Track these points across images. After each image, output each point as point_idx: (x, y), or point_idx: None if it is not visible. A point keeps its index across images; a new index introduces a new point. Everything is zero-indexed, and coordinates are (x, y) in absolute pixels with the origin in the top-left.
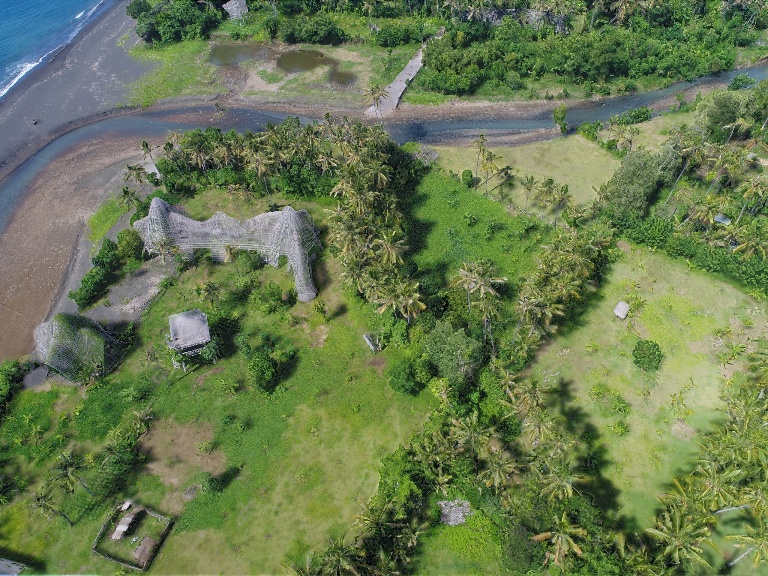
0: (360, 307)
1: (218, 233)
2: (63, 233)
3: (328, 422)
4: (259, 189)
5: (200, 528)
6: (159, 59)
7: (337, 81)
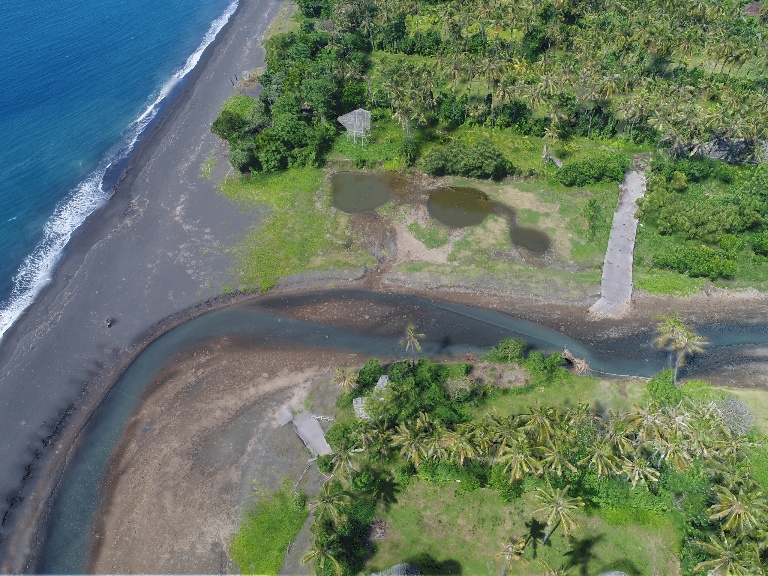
0: None
1: None
2: None
3: None
4: (510, 498)
5: None
6: (264, 201)
7: (524, 245)
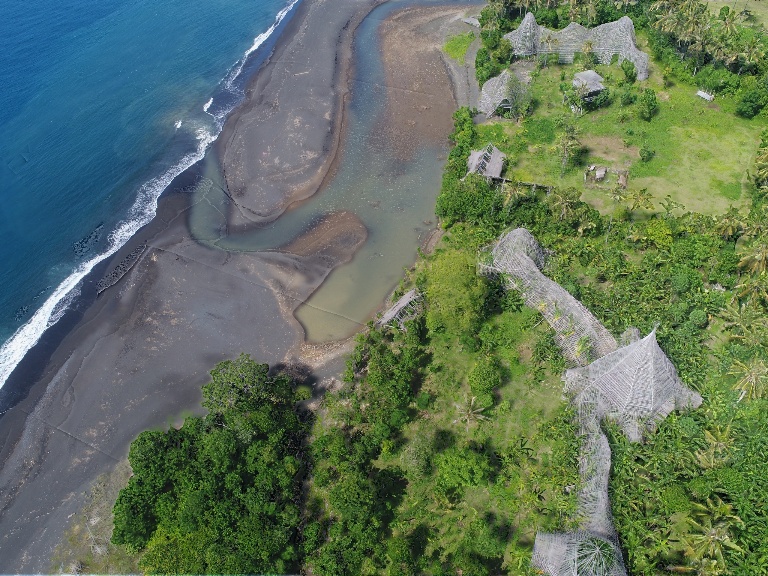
0: (687, 79)
1: (569, 39)
2: (428, 56)
3: (698, 133)
4: None
5: (646, 176)
6: None
7: None
